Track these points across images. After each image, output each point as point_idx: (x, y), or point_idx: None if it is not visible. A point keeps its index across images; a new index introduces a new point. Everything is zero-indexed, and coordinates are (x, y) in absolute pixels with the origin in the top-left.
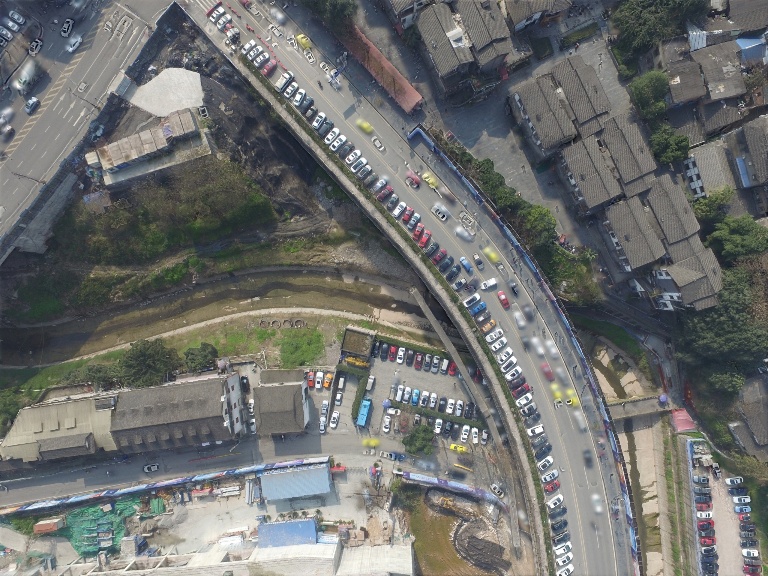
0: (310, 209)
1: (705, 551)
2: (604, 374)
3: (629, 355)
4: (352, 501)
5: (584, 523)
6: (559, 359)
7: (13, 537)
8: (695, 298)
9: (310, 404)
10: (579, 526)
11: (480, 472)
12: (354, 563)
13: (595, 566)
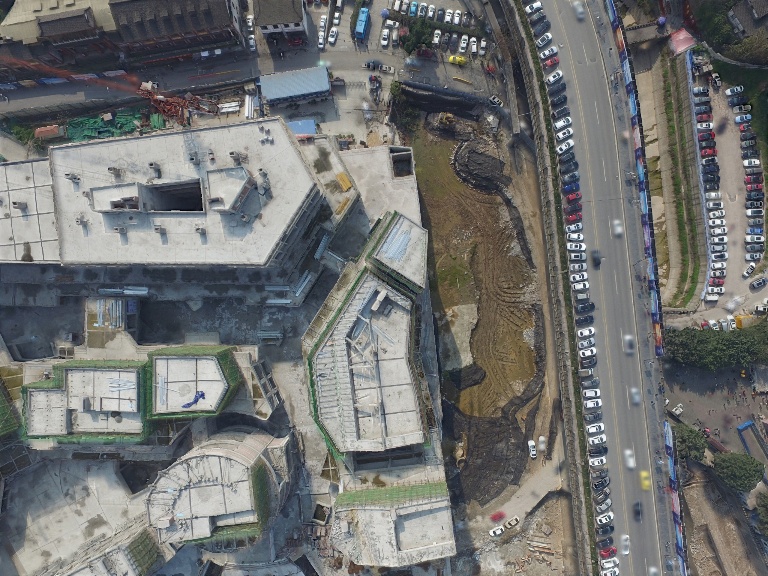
0: None
1: (706, 161)
2: None
3: None
4: (352, 116)
5: (584, 99)
6: None
7: (14, 149)
8: None
9: (308, 21)
10: (579, 103)
11: (479, 85)
12: None
13: (595, 142)
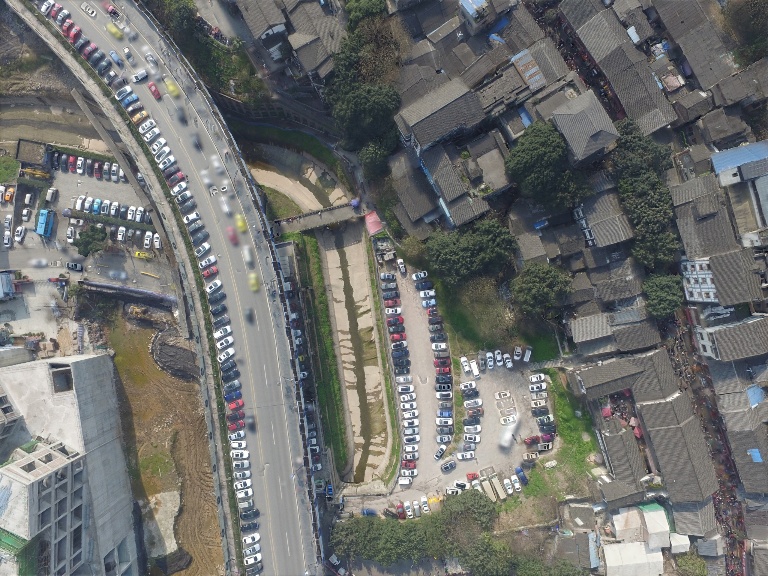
0: (0, 35)
1: (394, 346)
2: (313, 192)
3: (328, 167)
4: (41, 314)
5: (243, 307)
6: (212, 147)
7: None
8: (316, 64)
9: None
10: (239, 311)
11: (167, 278)
12: (26, 363)
13: (256, 349)
